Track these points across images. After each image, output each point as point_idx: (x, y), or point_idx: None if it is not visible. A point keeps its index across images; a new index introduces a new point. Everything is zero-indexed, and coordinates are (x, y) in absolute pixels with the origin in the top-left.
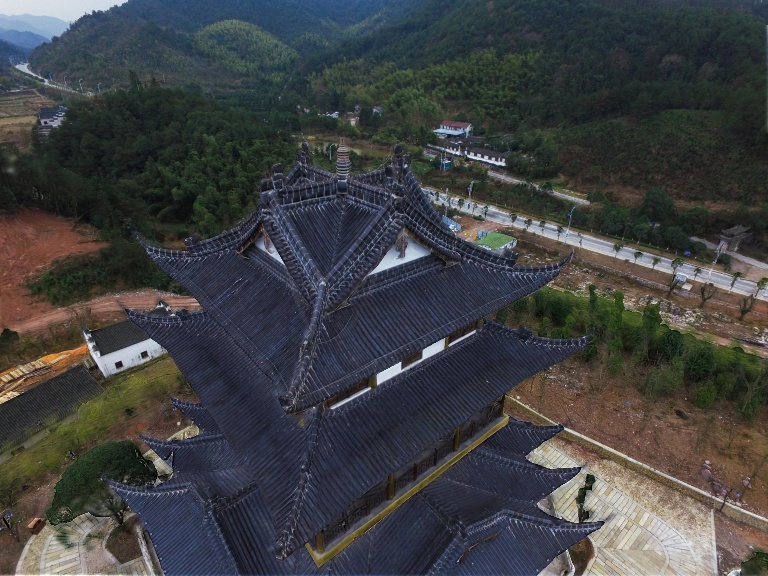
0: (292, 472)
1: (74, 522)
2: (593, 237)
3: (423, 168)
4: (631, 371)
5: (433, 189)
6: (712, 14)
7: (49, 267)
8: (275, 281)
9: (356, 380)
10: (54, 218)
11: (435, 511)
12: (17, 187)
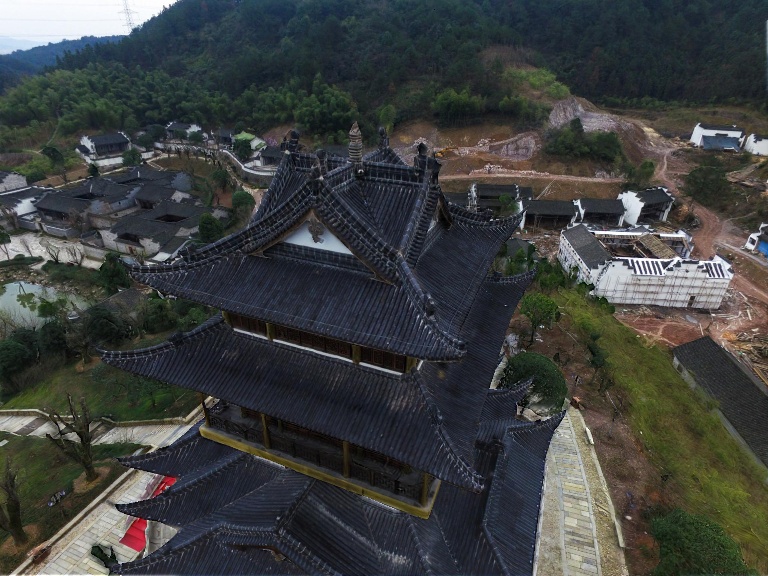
0: None
1: None
2: None
3: None
4: None
5: None
6: None
7: None
8: None
9: None
10: None
11: None
12: None
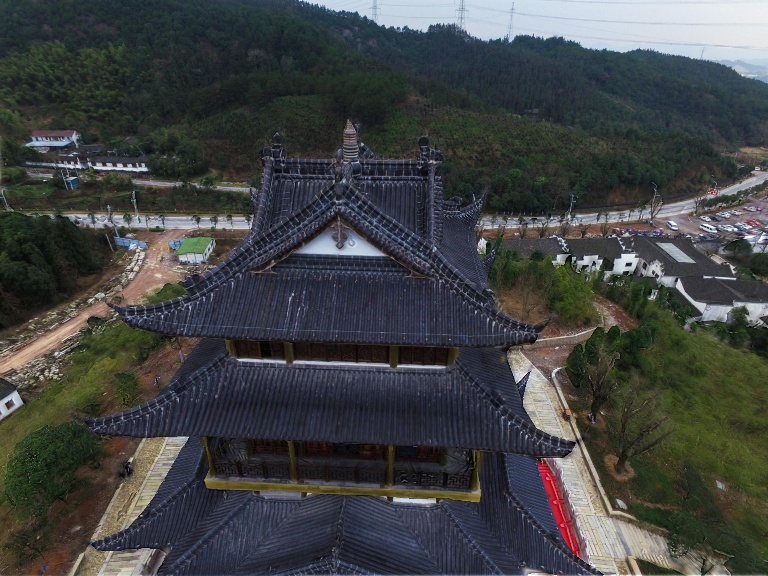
0: (481, 418)
1: None
2: None
3: (40, 192)
4: None
5: (76, 212)
6: (270, 14)
7: None
8: (344, 277)
9: None
10: None
11: None
12: None
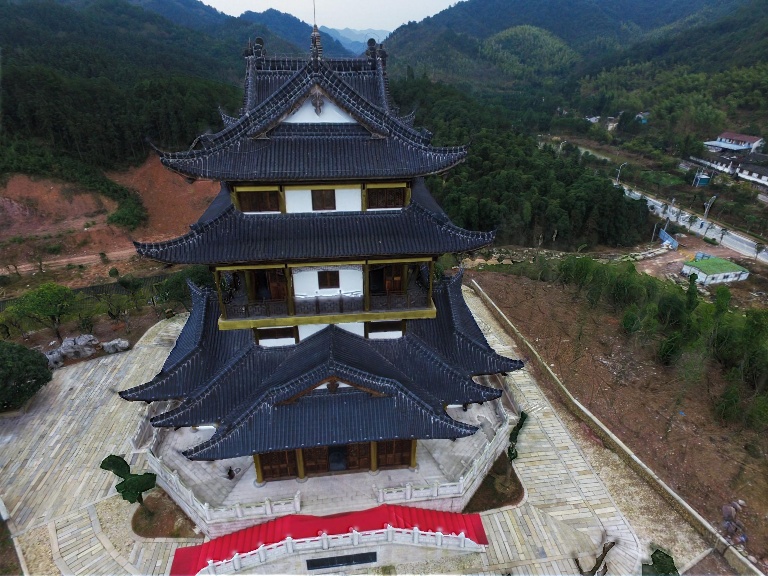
0: None
1: None
2: None
3: (670, 181)
4: (722, 392)
5: (668, 202)
6: None
7: None
8: None
9: (235, 176)
10: None
11: None
12: None
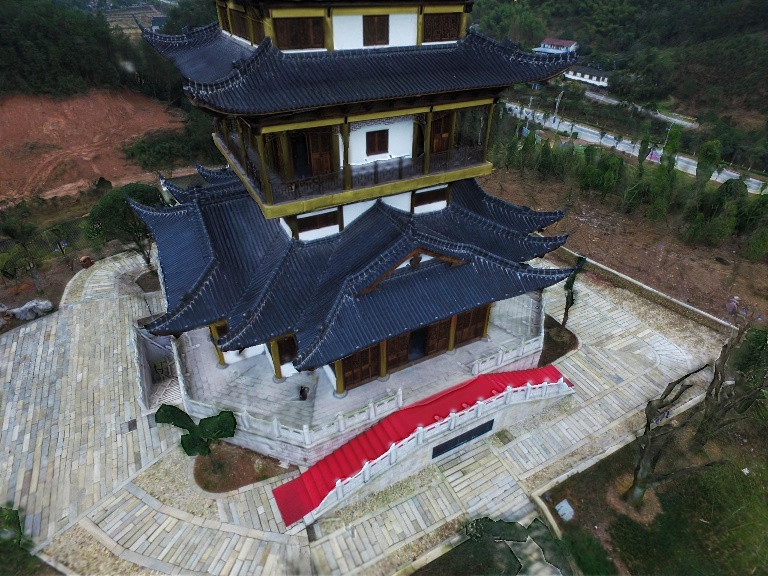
0: None
1: (115, 265)
2: (694, 160)
3: None
4: (677, 225)
5: (519, 105)
6: None
7: (142, 137)
8: None
9: None
10: (151, 101)
11: (395, 222)
12: (122, 68)
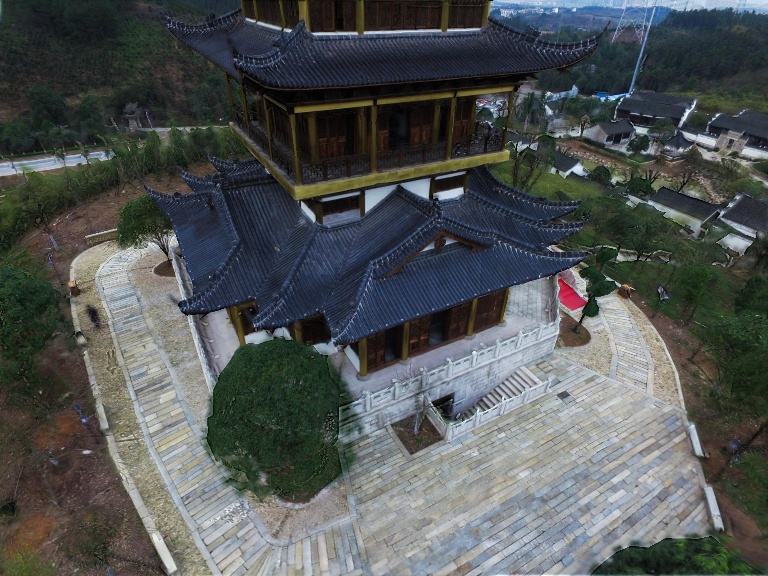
0: (523, 54)
1: (236, 571)
2: (13, 162)
3: None
4: None
5: None
6: None
7: None
8: None
9: None
10: None
11: None
12: None
